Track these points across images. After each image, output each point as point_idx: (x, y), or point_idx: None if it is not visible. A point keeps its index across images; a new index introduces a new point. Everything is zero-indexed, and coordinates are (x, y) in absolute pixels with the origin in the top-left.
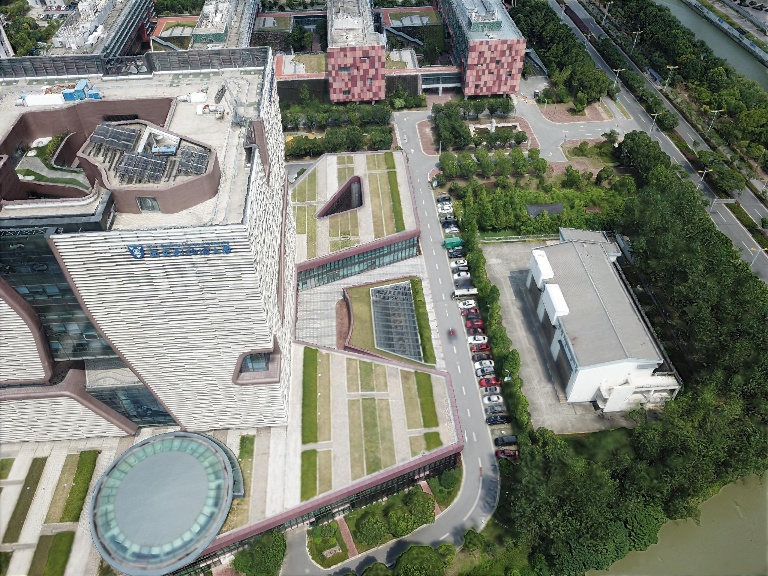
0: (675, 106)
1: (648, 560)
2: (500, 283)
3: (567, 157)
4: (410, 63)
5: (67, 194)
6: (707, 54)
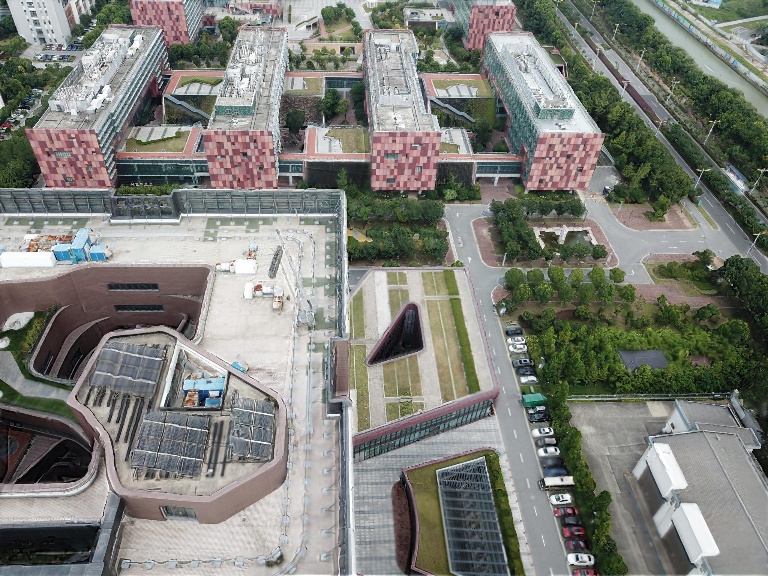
0: (766, 215)
1: None
2: (598, 466)
3: (653, 278)
4: (463, 146)
5: (49, 426)
6: None
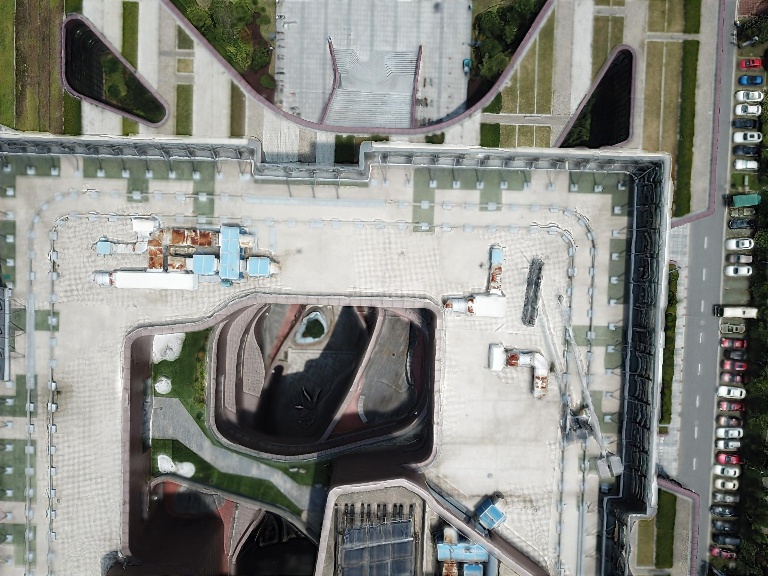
0: None
1: None
2: None
3: None
4: None
5: None
6: None
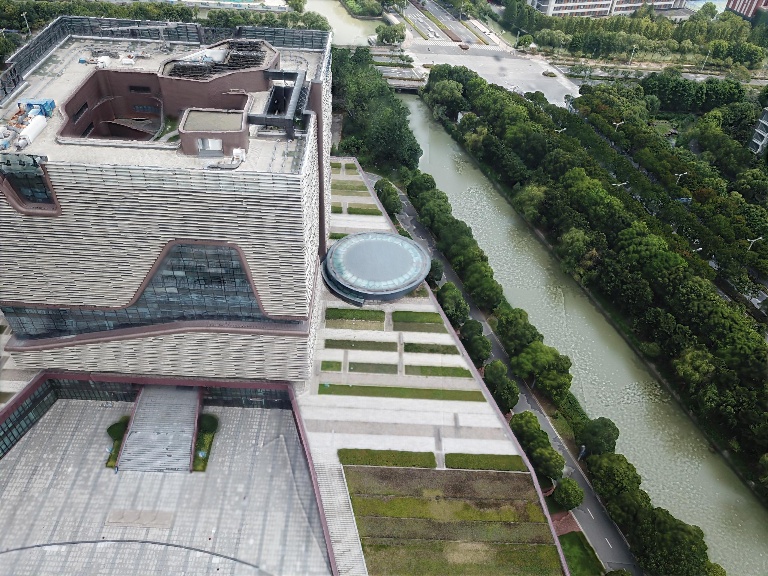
0: None
1: None
2: None
3: None
4: None
5: None
6: (11, 3)
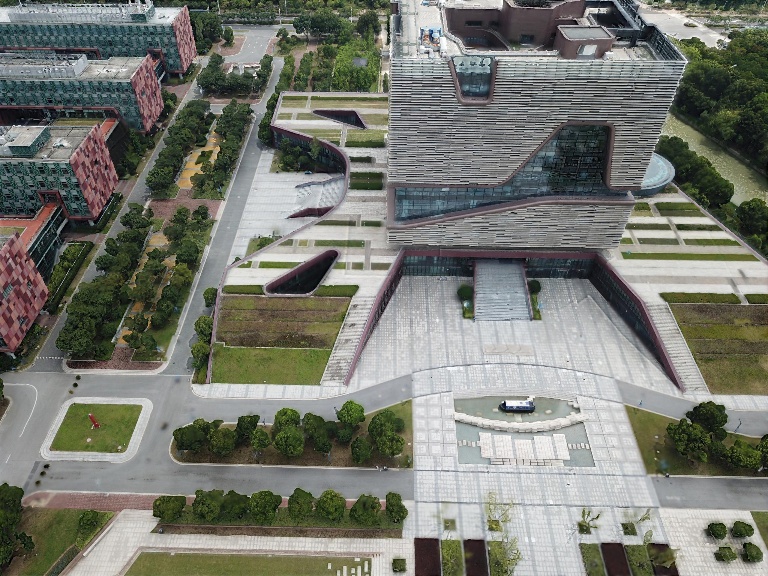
0: None
1: None
2: None
3: None
4: None
5: None
6: None
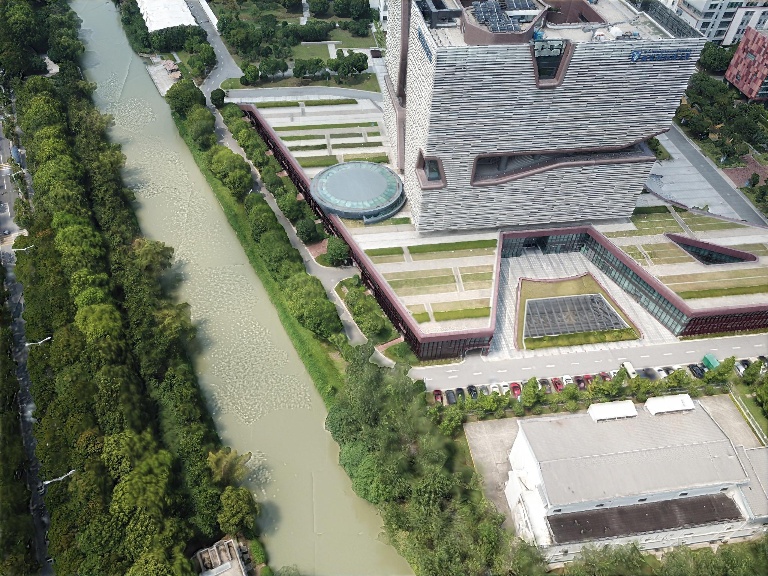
0: None
1: (360, 523)
2: None
3: None
4: None
5: None
6: None
